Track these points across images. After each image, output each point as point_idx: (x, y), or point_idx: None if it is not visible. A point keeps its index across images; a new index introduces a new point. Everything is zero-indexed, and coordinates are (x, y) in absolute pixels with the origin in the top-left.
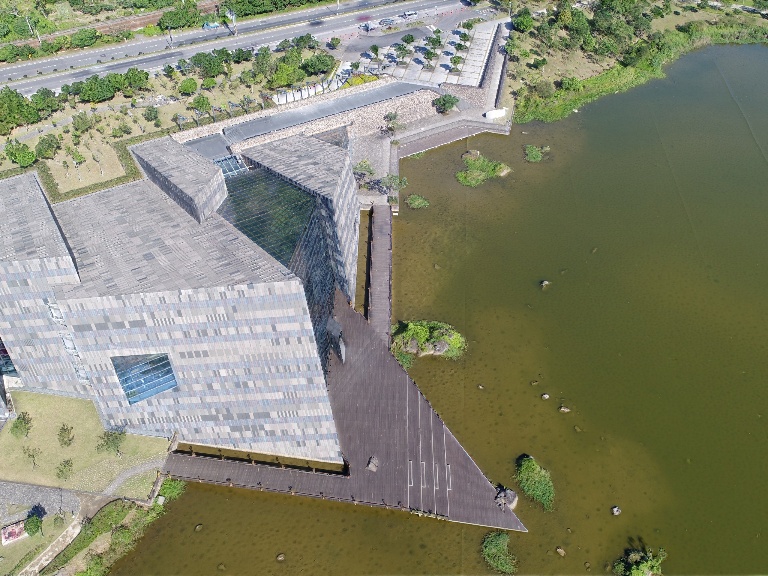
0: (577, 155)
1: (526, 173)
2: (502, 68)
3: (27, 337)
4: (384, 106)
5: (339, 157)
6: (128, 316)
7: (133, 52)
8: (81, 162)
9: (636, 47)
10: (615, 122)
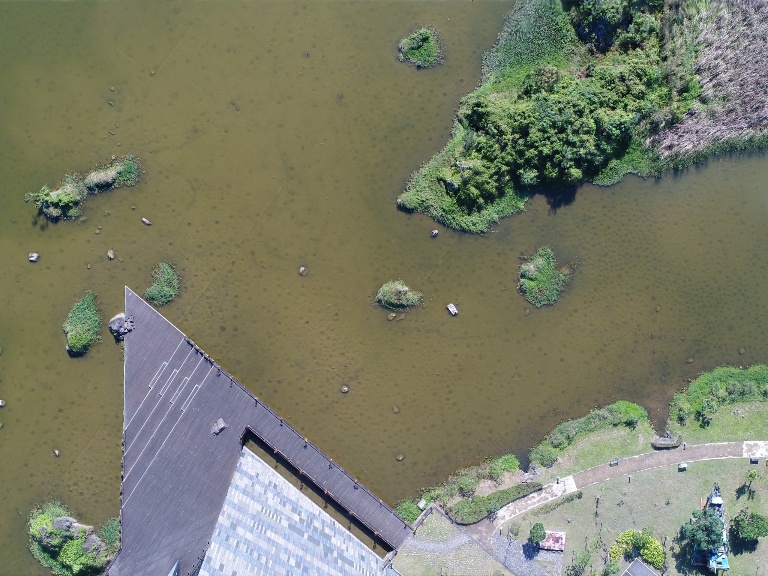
0: None
1: None
2: None
3: None
4: None
5: None
6: None
7: None
8: None
9: None
10: None
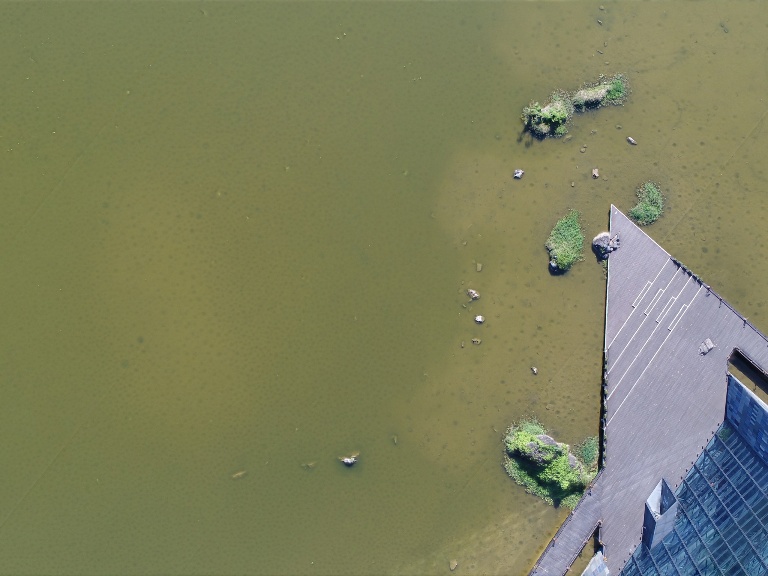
0: None
1: None
2: None
3: None
4: None
5: None
6: None
7: None
8: None
9: None
10: None
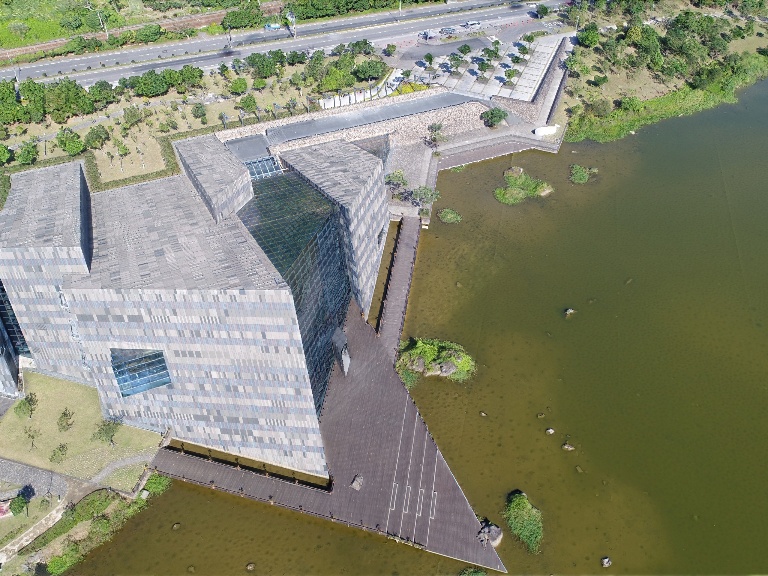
0: (626, 179)
1: (569, 194)
2: (560, 84)
3: (40, 321)
4: (430, 116)
5: (370, 166)
6: (127, 310)
7: (194, 49)
8: (126, 154)
9: (708, 69)
10: (674, 147)
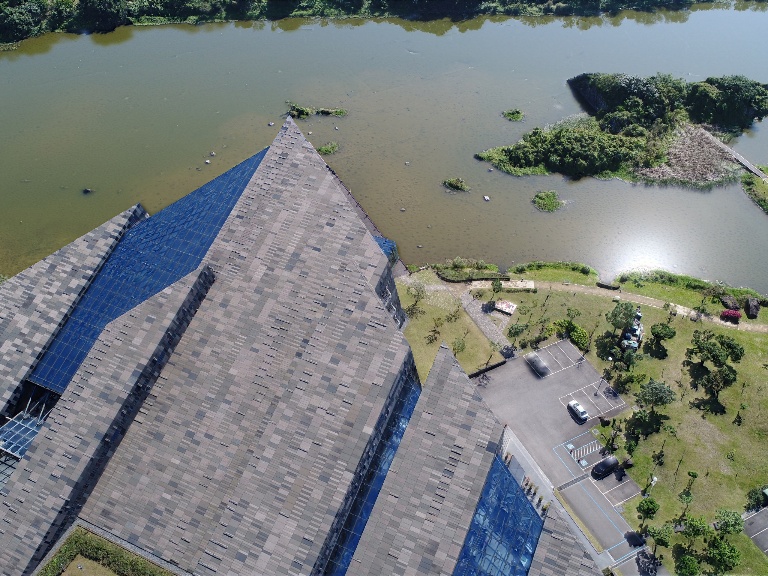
0: None
1: None
2: None
3: None
4: None
5: (8, 288)
6: None
7: None
8: None
9: None
10: None
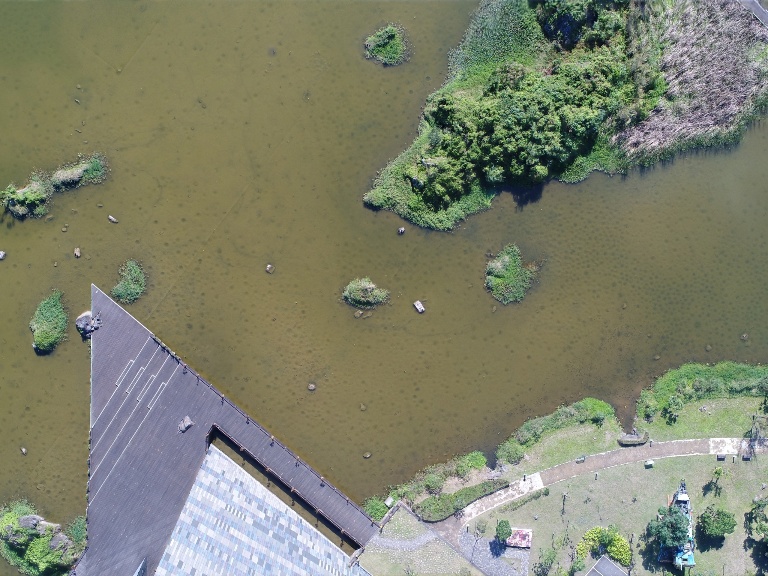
0: None
1: None
2: None
3: None
4: None
5: None
6: None
7: None
8: None
9: None
10: None
